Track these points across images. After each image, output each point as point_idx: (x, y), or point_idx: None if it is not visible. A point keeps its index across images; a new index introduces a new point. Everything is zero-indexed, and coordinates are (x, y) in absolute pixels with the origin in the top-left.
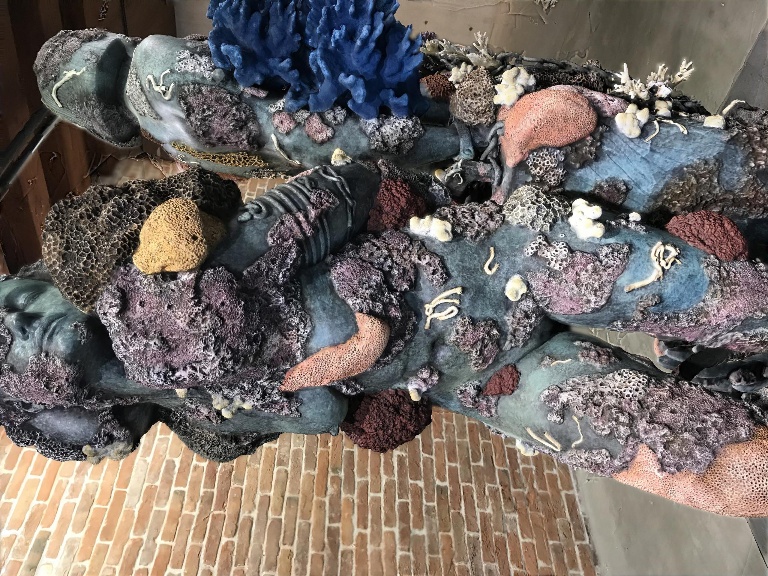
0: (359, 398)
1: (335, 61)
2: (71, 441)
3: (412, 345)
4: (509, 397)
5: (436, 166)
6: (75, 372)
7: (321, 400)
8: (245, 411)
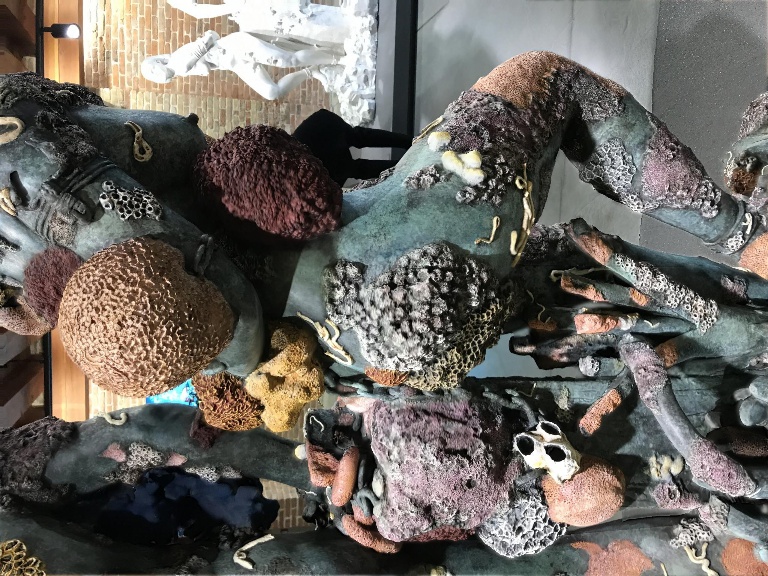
0: None
1: None
2: None
3: None
4: None
5: (314, 544)
6: None
7: None
8: None
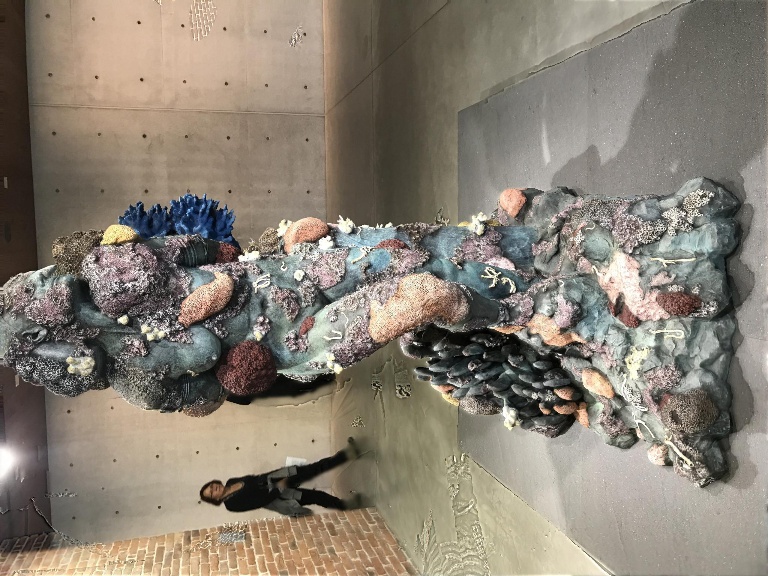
0: (228, 349)
1: (190, 226)
2: (59, 359)
3: (250, 304)
4: (312, 329)
5: None
6: (71, 293)
7: (204, 333)
8: (160, 344)
